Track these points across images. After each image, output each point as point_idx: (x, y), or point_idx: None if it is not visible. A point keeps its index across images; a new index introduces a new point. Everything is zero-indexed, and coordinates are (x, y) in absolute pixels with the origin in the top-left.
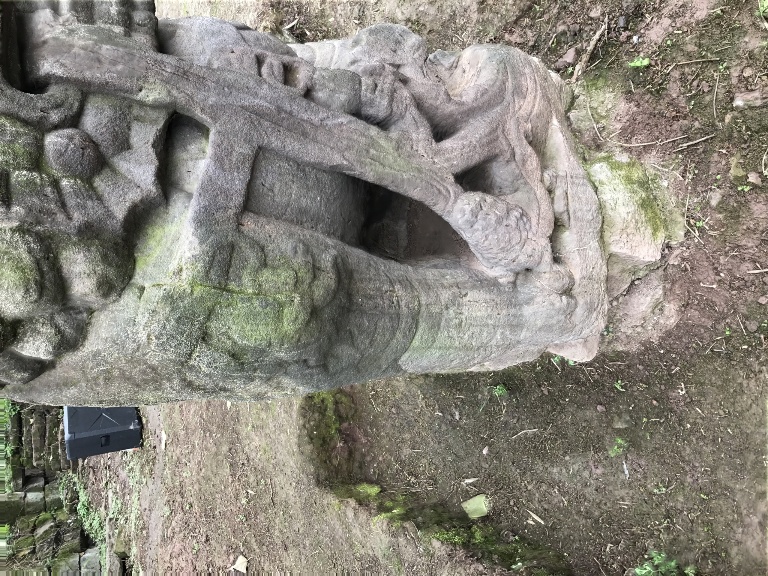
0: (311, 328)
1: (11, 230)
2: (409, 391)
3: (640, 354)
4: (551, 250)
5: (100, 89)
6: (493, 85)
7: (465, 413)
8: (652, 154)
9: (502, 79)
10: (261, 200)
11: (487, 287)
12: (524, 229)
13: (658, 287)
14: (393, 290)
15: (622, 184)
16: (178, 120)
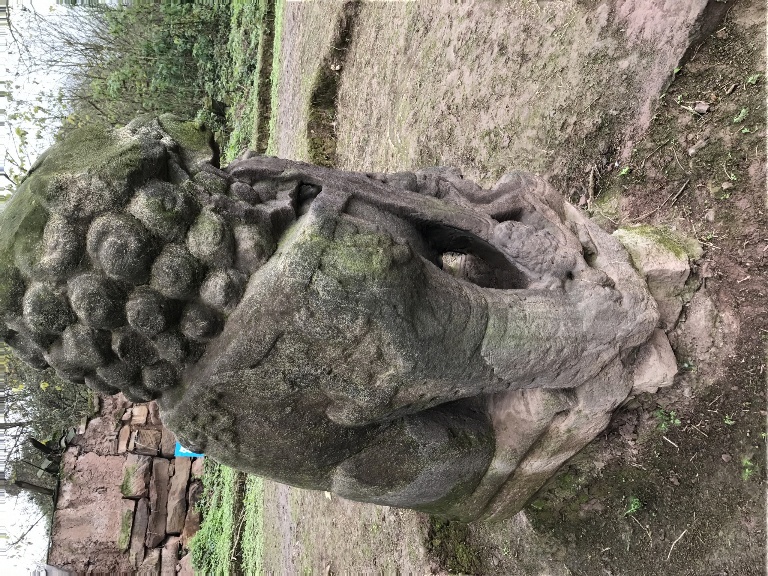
0: (394, 273)
1: (210, 210)
2: (557, 575)
3: (729, 376)
4: (583, 257)
5: (261, 174)
6: (511, 182)
7: (617, 567)
8: (657, 217)
9: (516, 179)
10: (355, 215)
11: (541, 292)
12: (553, 240)
13: (706, 300)
14: (462, 289)
15: (638, 235)
16: (305, 198)
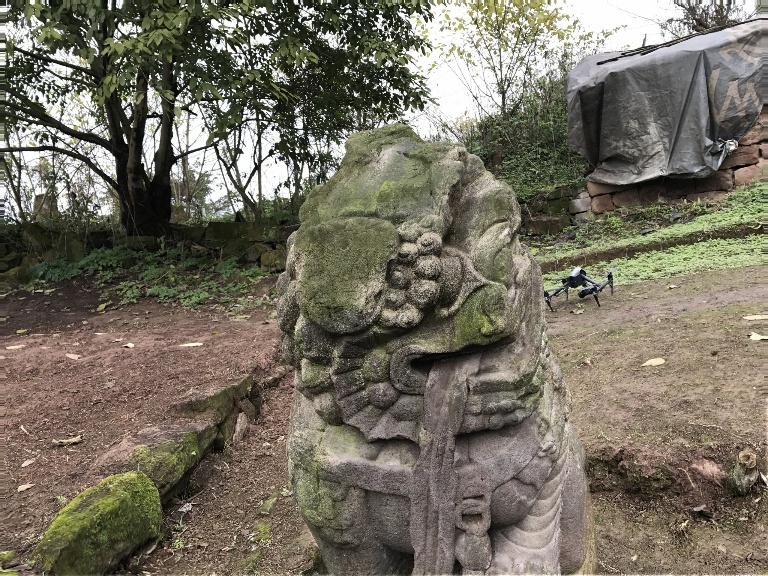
0: (311, 525)
1: None
2: None
3: None
4: None
5: None
6: None
7: None
8: None
9: None
10: (378, 498)
11: None
12: None
13: None
14: None
15: None
16: None
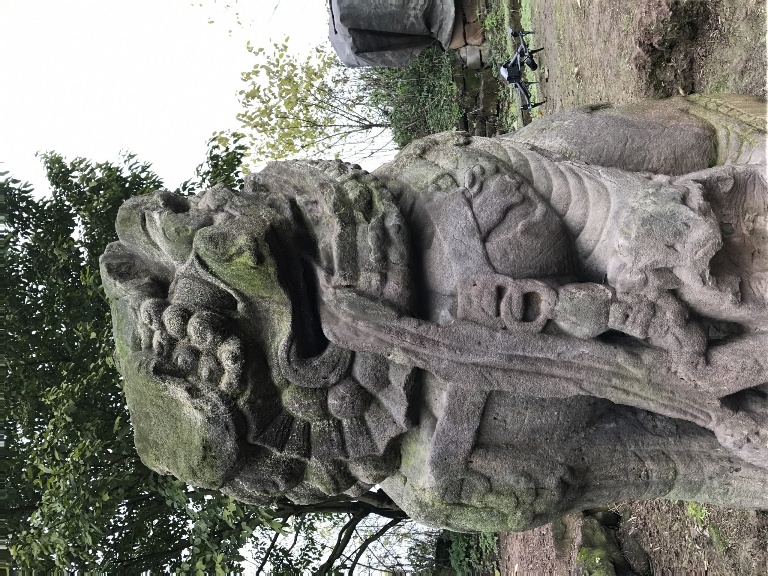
0: (536, 524)
1: None
2: None
3: None
4: None
5: None
6: None
7: None
8: None
9: None
10: (493, 432)
11: (767, 470)
12: None
13: None
14: (643, 465)
15: None
16: None
